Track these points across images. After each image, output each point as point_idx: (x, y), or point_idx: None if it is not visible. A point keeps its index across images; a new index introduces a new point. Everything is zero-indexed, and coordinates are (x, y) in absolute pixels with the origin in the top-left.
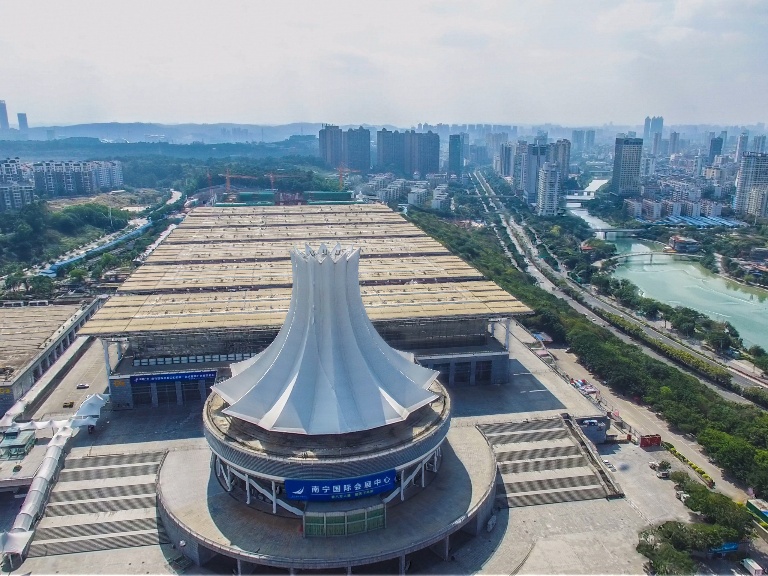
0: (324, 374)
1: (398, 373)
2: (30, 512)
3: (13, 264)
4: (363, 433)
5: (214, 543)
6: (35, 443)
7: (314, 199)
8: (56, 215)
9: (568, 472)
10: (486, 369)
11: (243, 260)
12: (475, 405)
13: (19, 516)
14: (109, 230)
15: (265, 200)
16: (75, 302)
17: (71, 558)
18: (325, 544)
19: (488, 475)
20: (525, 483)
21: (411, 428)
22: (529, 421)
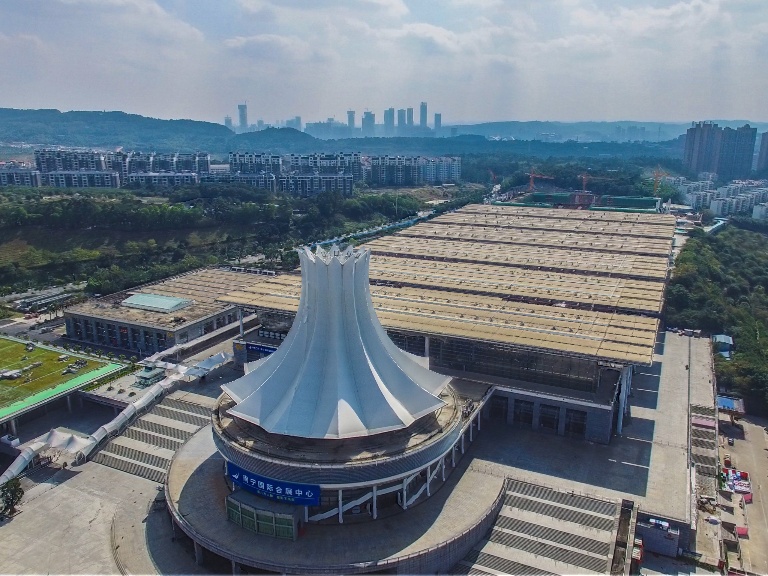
0: (300, 373)
1: (377, 391)
2: (108, 428)
3: (291, 240)
4: (306, 440)
5: (168, 496)
6: (162, 379)
7: (598, 204)
8: (349, 202)
9: (571, 570)
10: (579, 420)
11: (432, 258)
12: (534, 457)
13: (100, 428)
14: (393, 219)
15: (557, 202)
16: None
17: (110, 471)
18: (234, 532)
19: (451, 533)
20: (505, 561)
21: (362, 451)
22: (575, 494)
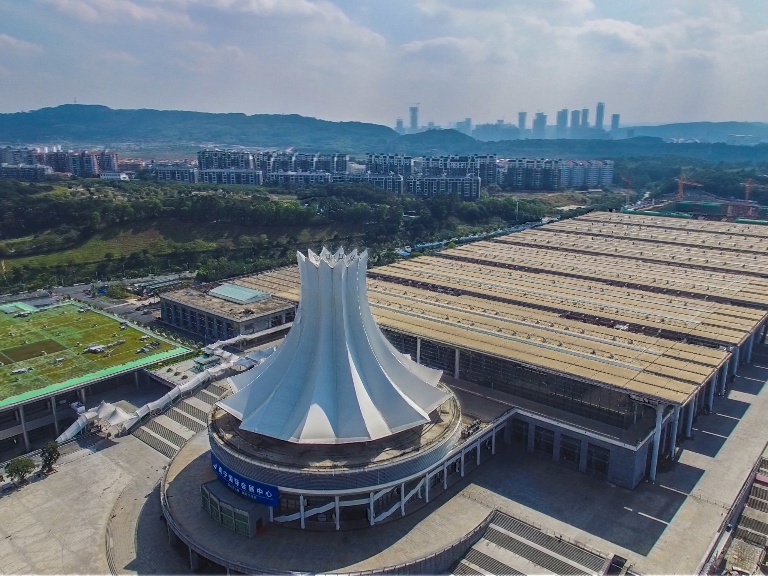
0: None
1: (354, 400)
2: (152, 406)
3: (397, 241)
4: None
5: (165, 476)
6: None
7: (748, 216)
8: (466, 205)
9: None
10: (601, 458)
11: (514, 266)
12: (538, 491)
13: (144, 405)
14: (512, 224)
15: None
16: (375, 277)
17: (142, 446)
18: (202, 520)
19: (405, 558)
20: None
21: (326, 459)
22: (563, 540)
